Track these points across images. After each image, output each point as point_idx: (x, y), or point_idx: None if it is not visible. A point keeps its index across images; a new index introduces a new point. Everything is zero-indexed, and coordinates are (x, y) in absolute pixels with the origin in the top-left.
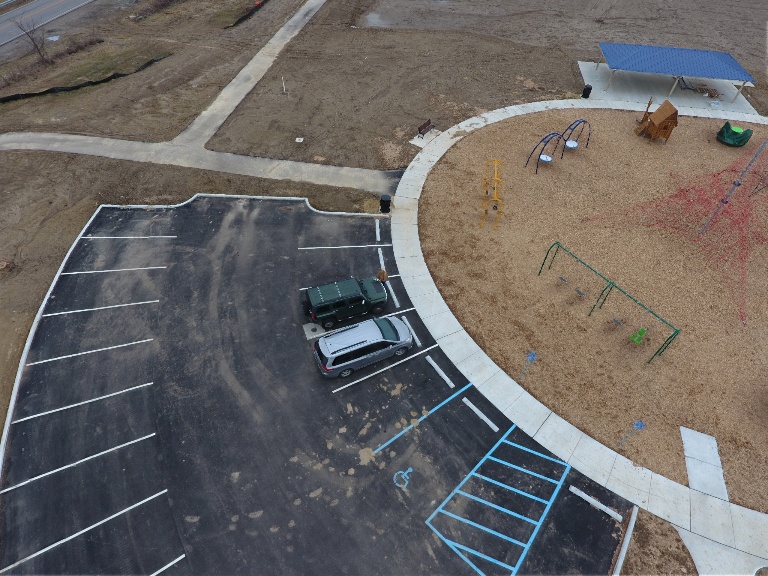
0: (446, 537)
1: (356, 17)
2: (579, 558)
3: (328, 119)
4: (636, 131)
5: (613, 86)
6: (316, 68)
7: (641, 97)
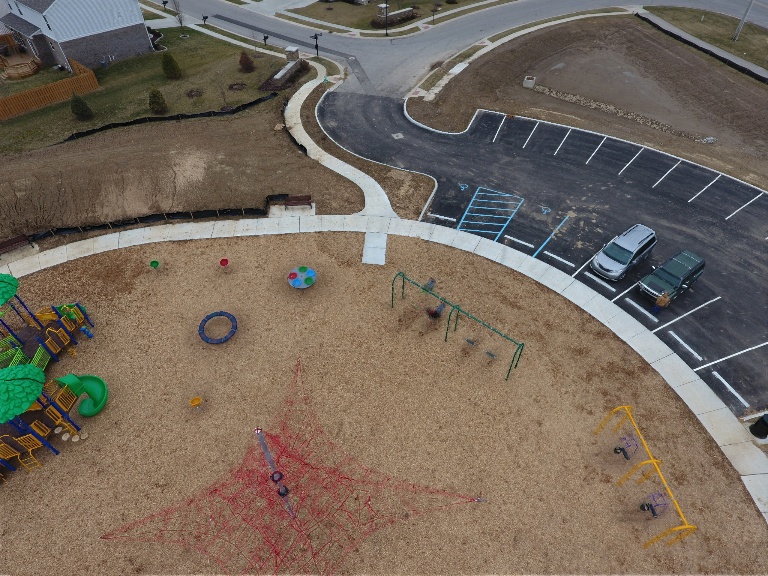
0: (512, 196)
1: None
2: (448, 200)
3: None
4: None
5: None
6: None
7: None
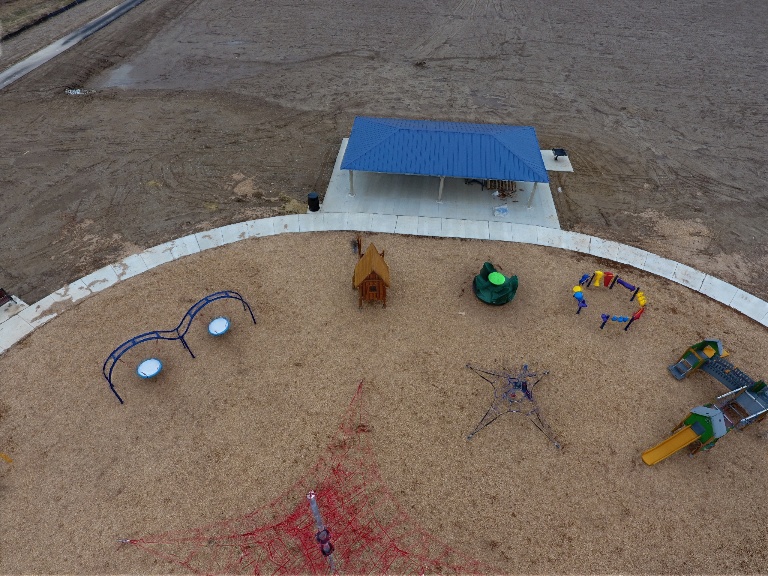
0: None
1: (93, 74)
2: None
3: None
4: (352, 280)
5: (368, 184)
6: None
7: (399, 203)
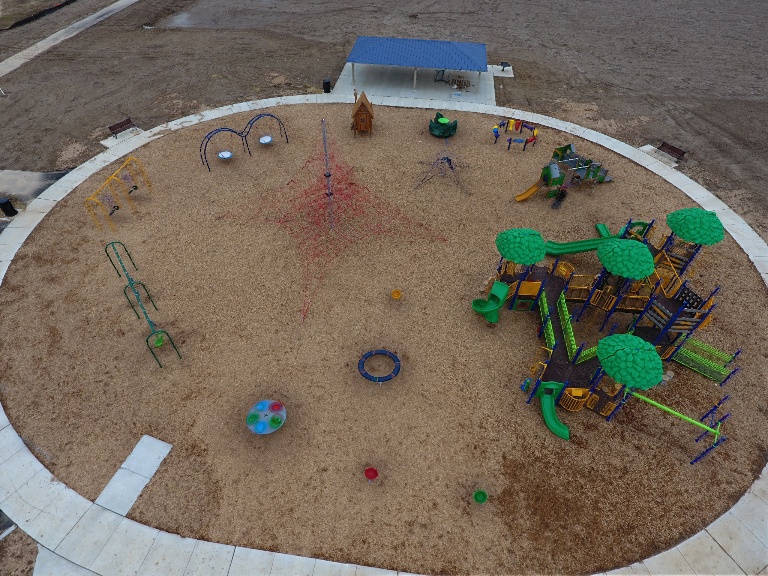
0: None
1: (161, 17)
2: None
3: (28, 121)
4: (351, 125)
5: (365, 80)
6: (62, 69)
7: (386, 90)
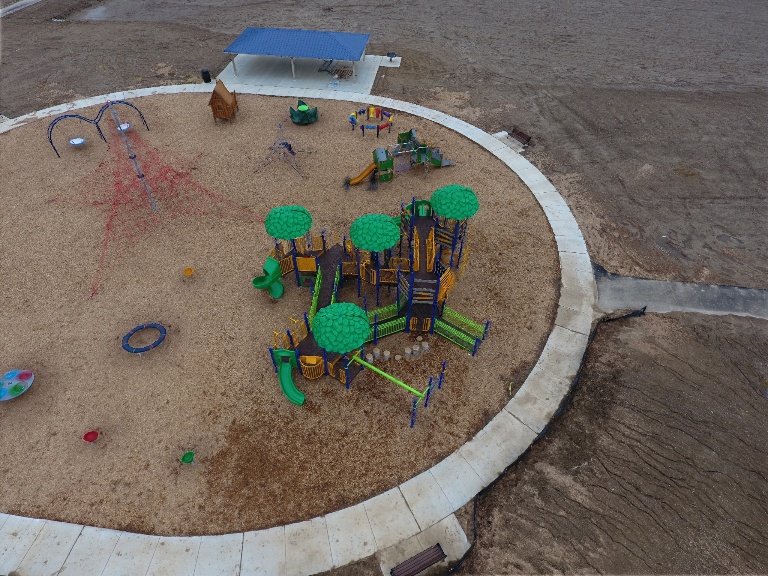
0: None
1: (75, 11)
2: None
3: None
4: None
5: (250, 70)
6: None
7: (266, 80)
